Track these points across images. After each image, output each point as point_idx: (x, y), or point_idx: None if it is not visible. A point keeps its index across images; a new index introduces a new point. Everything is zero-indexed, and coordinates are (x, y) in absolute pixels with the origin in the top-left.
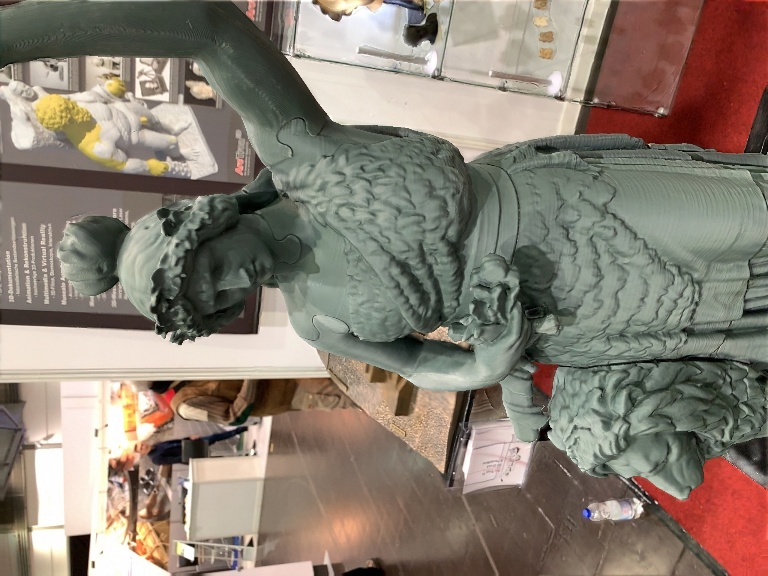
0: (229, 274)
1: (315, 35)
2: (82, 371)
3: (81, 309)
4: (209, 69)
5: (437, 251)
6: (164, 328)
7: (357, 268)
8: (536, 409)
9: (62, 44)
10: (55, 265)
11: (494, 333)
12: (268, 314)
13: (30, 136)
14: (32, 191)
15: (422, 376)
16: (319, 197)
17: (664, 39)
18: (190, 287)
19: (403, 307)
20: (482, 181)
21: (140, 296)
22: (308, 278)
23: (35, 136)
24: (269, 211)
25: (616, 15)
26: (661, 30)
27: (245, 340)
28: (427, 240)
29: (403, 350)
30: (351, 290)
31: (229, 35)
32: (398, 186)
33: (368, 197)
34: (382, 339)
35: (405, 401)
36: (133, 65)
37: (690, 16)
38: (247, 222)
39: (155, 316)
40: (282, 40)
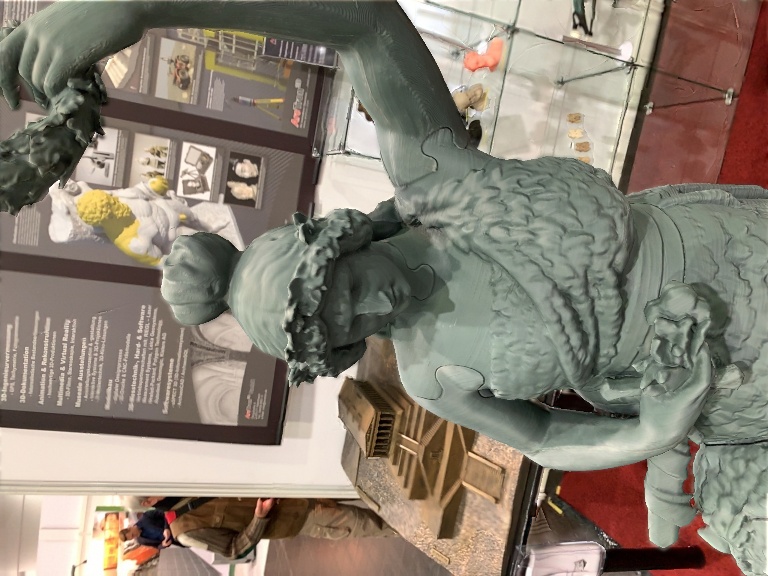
0: (368, 296)
1: (355, 143)
2: (86, 484)
3: (95, 412)
4: (362, 62)
5: (602, 281)
6: (294, 354)
7: (506, 301)
8: (686, 498)
9: (223, 6)
10: (74, 363)
11: (679, 379)
12: (292, 424)
13: (67, 229)
14: (61, 285)
15: (554, 451)
16: (465, 216)
17: (686, 158)
18: (327, 306)
19: (563, 348)
20: (636, 212)
21: (264, 316)
22: (438, 319)
23: (72, 230)
24: (396, 240)
25: (641, 134)
26: (683, 150)
27: (266, 452)
28: (593, 266)
29: (532, 418)
30: (497, 328)
31: (391, 23)
32: (562, 202)
33: (527, 214)
34: (527, 393)
35: (450, 521)
36: (178, 165)
37: (709, 138)
38: (377, 247)
39: (289, 335)
40: (324, 146)
